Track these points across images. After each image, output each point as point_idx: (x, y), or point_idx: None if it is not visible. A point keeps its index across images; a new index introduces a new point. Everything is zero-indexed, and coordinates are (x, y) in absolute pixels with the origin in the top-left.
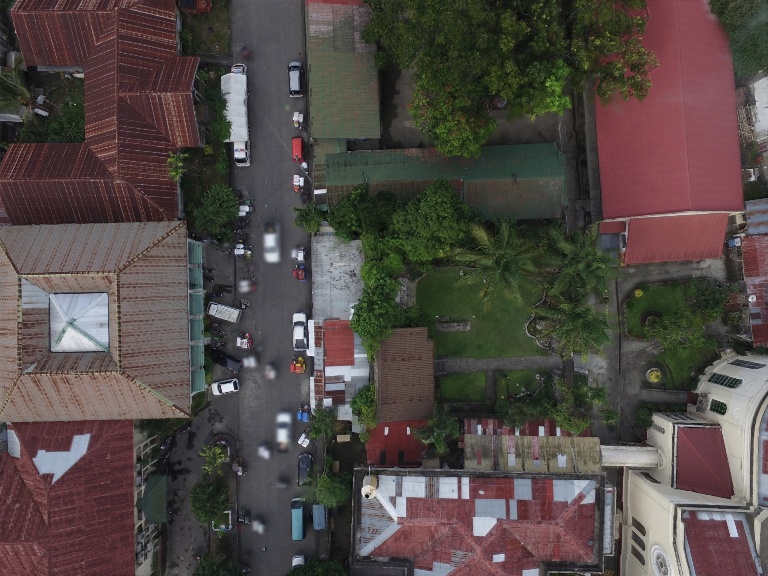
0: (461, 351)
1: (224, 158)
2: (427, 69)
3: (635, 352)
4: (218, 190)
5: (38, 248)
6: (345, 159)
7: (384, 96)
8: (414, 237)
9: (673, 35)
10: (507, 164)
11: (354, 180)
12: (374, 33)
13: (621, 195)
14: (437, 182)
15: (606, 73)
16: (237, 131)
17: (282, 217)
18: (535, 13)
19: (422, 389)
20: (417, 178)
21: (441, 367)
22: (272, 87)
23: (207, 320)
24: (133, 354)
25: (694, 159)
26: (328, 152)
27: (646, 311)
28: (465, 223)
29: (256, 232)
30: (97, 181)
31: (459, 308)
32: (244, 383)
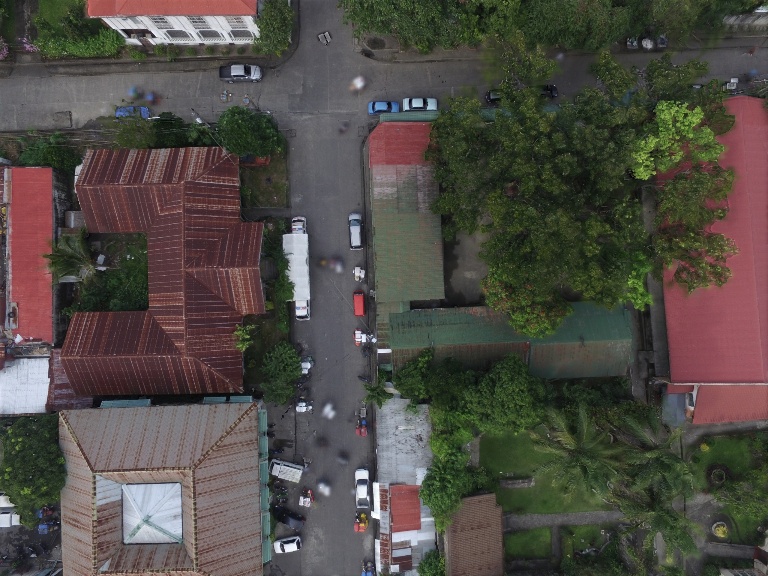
0: (525, 507)
1: (284, 313)
2: (510, 274)
3: (700, 505)
4: (281, 352)
5: (110, 438)
6: (409, 319)
7: (445, 247)
8: (489, 421)
9: (744, 203)
10: (573, 325)
11: (420, 344)
12: (444, 209)
13: (690, 359)
14: (510, 360)
15: (685, 262)
16: (300, 292)
17: (343, 370)
18: (617, 211)
19: (491, 557)
20: (483, 341)
21: (505, 523)
22: (331, 238)
23: (269, 479)
24: (208, 549)
25: (766, 328)
26: (391, 311)
27: (711, 463)
28: (541, 408)
29: (316, 385)
30: (164, 357)
31: (523, 463)
32: (306, 539)
